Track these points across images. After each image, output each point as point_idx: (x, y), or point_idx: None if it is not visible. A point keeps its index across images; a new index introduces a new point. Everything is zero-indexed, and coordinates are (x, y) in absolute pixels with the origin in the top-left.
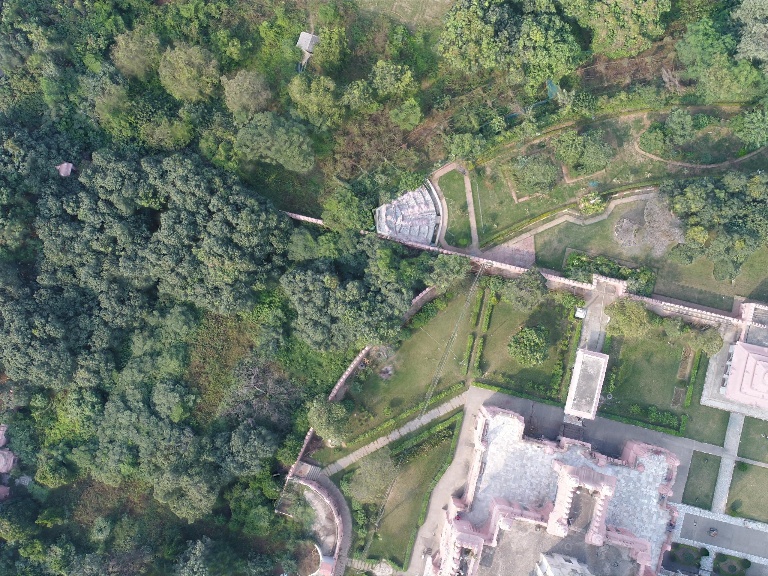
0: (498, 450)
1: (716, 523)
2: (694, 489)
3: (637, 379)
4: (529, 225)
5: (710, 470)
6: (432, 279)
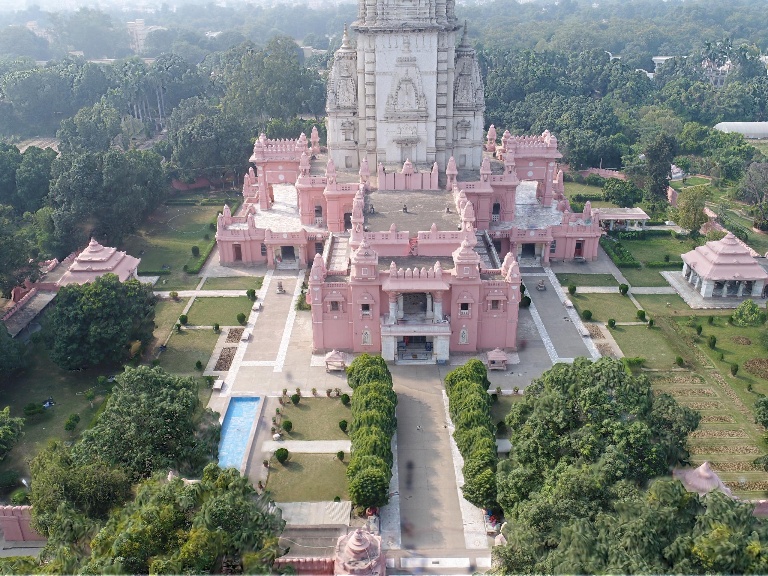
0: (531, 183)
1: (552, 290)
2: (575, 277)
3: (645, 247)
4: (709, 202)
5: (602, 282)
6: (627, 159)
